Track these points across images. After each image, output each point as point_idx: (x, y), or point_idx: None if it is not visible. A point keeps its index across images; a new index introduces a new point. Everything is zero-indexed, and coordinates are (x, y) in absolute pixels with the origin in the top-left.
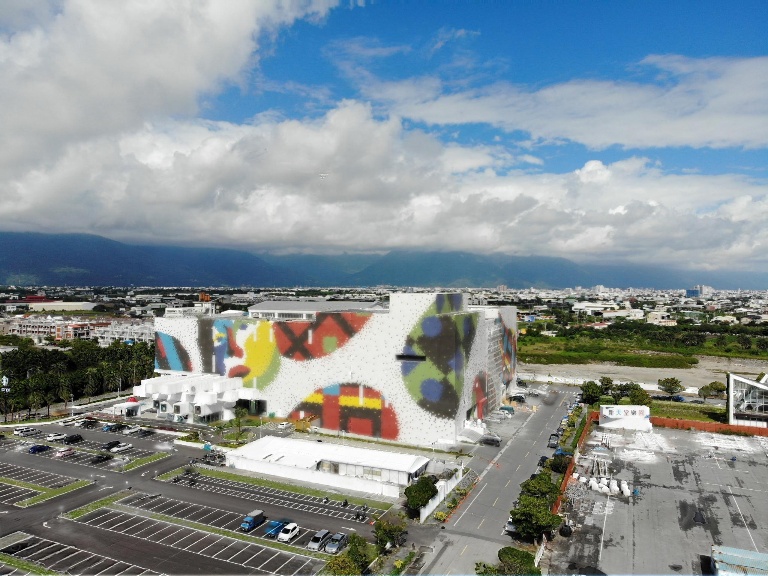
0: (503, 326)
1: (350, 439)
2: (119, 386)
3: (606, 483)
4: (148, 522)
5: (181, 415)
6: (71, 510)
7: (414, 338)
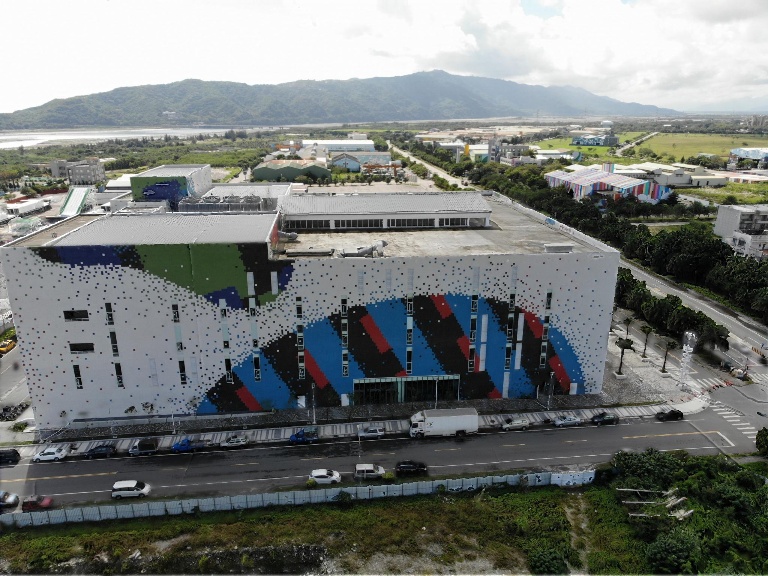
0: None
1: None
2: None
3: None
4: None
5: None
6: None
7: None
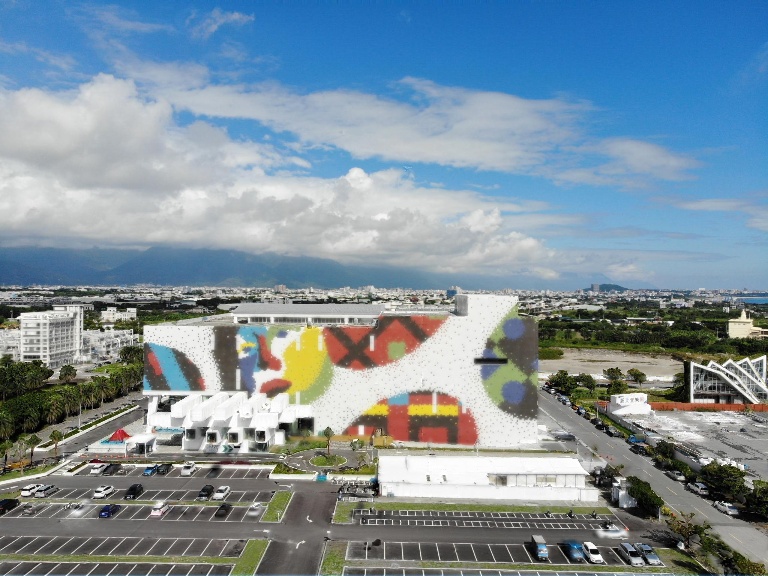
0: None
1: (446, 450)
2: (60, 416)
3: None
4: (431, 573)
5: (234, 444)
6: None
7: (495, 341)
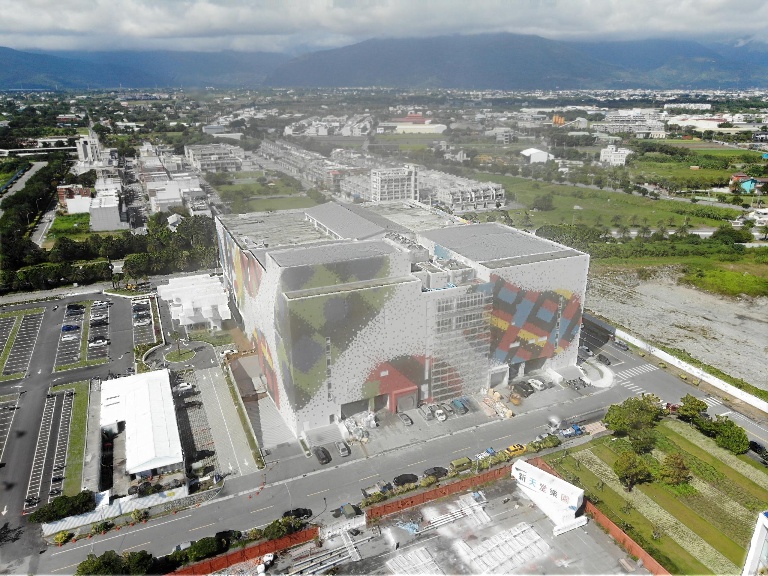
0: (515, 290)
1: (231, 393)
2: None
3: None
4: None
5: None
6: None
7: (276, 311)
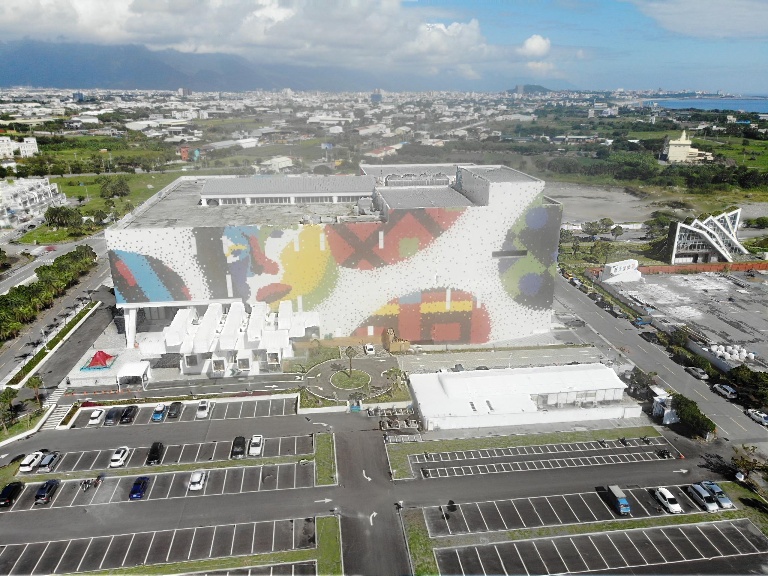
0: None
1: (466, 352)
2: None
3: (724, 350)
4: (524, 548)
5: None
6: (409, 572)
7: (516, 232)
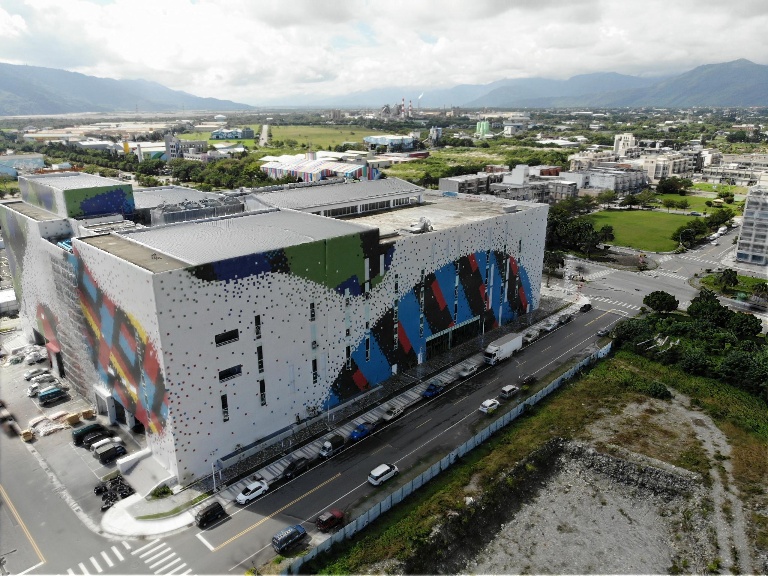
0: None
1: None
2: None
3: None
4: None
5: None
6: None
7: None
